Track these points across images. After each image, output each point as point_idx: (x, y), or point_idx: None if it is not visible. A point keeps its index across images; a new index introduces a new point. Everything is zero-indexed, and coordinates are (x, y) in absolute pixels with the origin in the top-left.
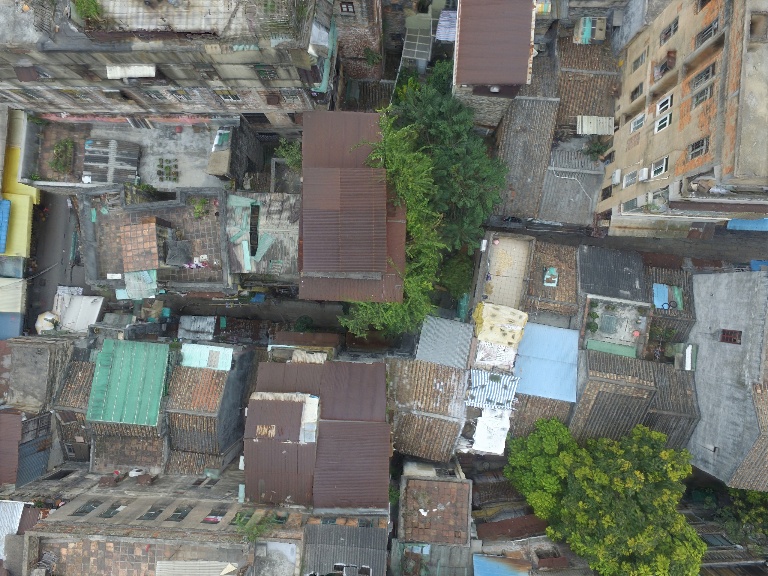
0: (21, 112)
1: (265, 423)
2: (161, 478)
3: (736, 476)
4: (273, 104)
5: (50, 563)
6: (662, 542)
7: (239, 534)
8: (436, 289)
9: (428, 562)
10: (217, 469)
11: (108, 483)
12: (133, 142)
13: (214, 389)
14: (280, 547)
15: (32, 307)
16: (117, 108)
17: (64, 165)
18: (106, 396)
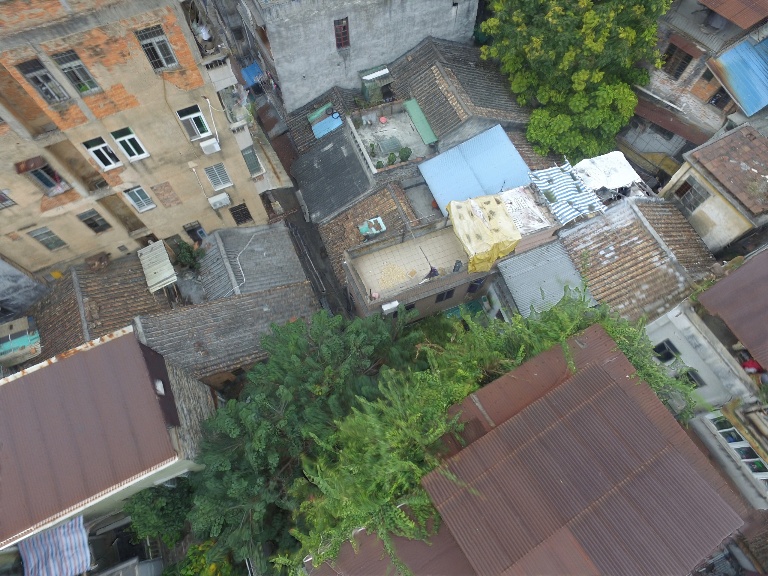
0: None
1: None
2: None
3: None
4: None
5: None
6: None
7: None
8: None
9: None
10: None
11: None
12: None
13: None
14: None
15: None
16: None
17: None
18: None
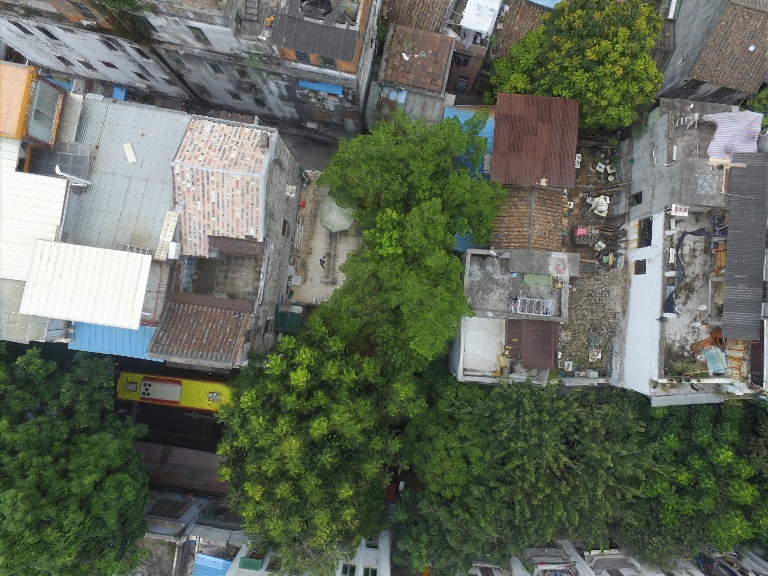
0: None
1: None
2: None
3: (700, 61)
4: None
5: None
6: None
7: None
8: None
9: None
10: None
11: None
12: None
13: None
14: None
15: None
16: None
17: None
18: None
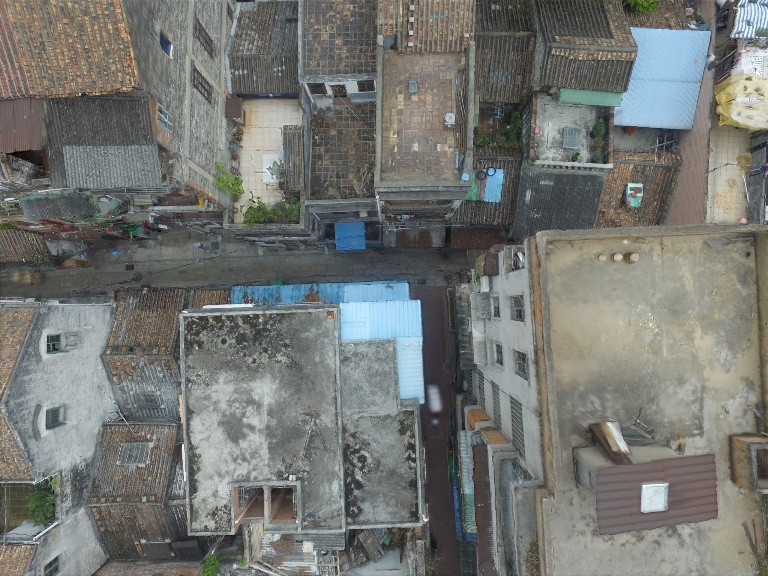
0: None
1: None
2: None
3: None
4: None
5: None
6: None
7: None
8: None
9: None
10: None
11: None
12: None
13: None
14: None
15: None
16: None
17: None
18: None
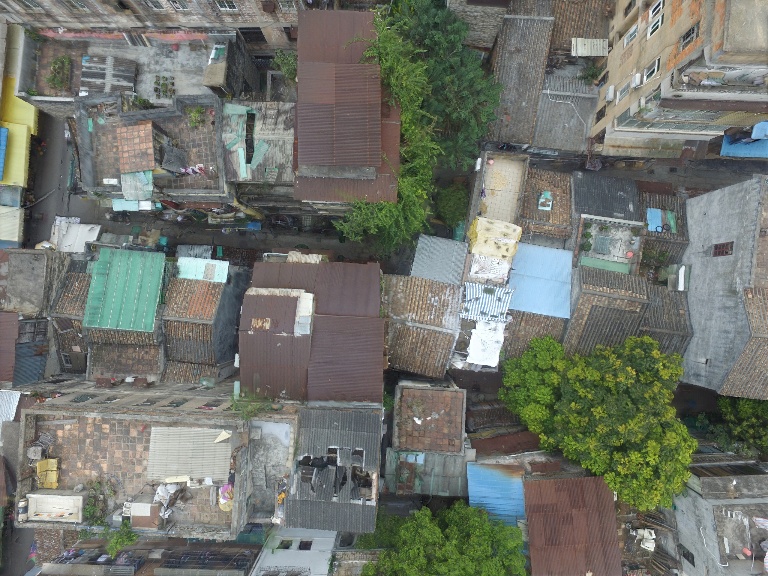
0: (19, 42)
1: (260, 316)
2: (157, 385)
3: (727, 382)
4: (269, 11)
5: (46, 444)
6: (653, 432)
7: (234, 415)
8: (432, 222)
9: (422, 471)
10: (213, 377)
11: (104, 384)
12: (130, 60)
13: (210, 299)
14: (274, 431)
15: (30, 241)
16: (114, 21)
17: (61, 81)
18: (103, 303)
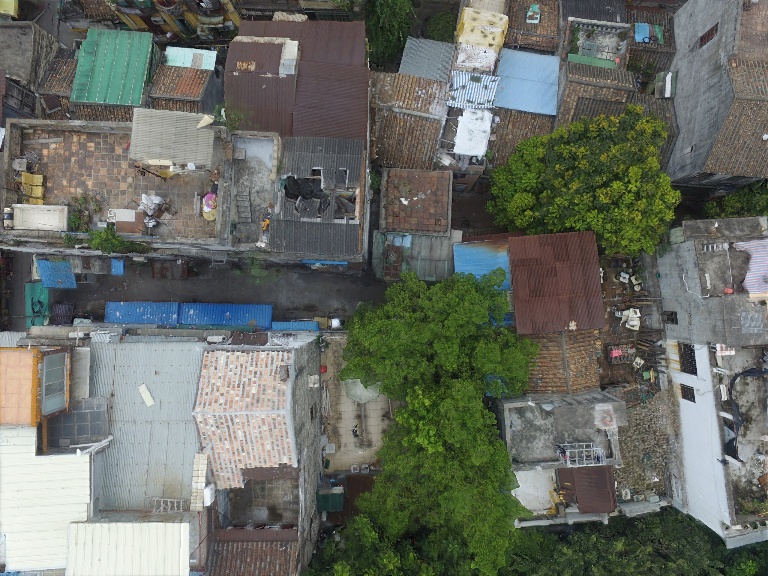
0: None
1: (245, 60)
2: None
3: (712, 157)
4: None
5: (32, 161)
6: None
7: None
8: None
9: (409, 255)
10: None
11: None
12: None
13: (198, 82)
14: (259, 154)
15: None
16: None
17: None
18: (90, 80)
